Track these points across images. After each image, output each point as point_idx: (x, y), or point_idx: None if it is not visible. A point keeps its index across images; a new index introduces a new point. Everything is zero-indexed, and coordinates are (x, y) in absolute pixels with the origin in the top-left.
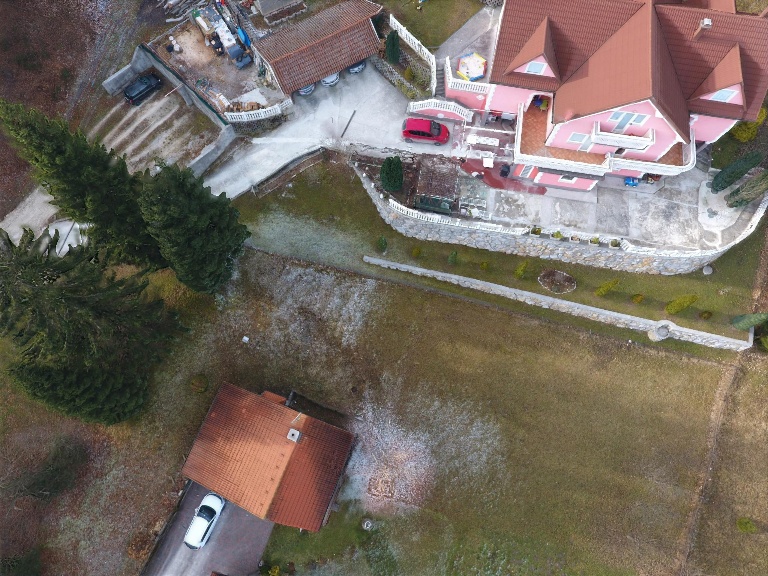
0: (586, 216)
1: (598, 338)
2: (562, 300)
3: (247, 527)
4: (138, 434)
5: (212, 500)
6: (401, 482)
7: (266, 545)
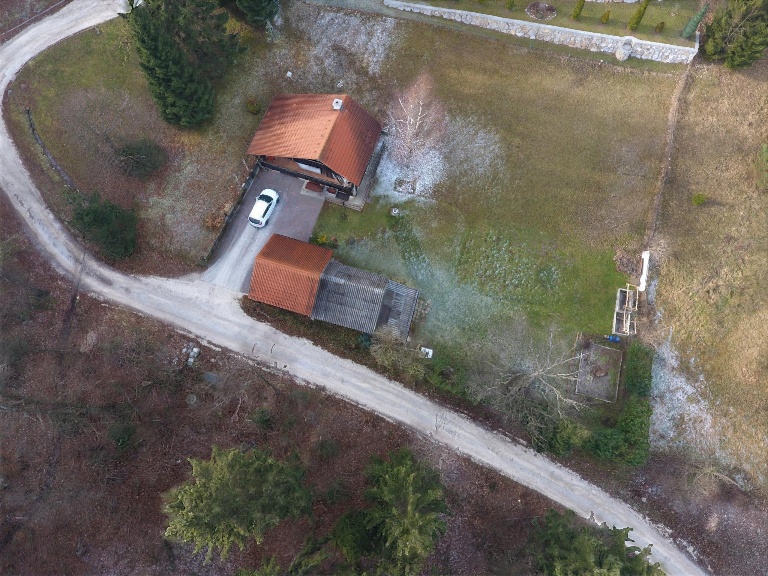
0: None
1: (576, 60)
2: (545, 25)
3: (298, 215)
4: (207, 141)
5: (269, 191)
6: (421, 182)
7: (314, 227)
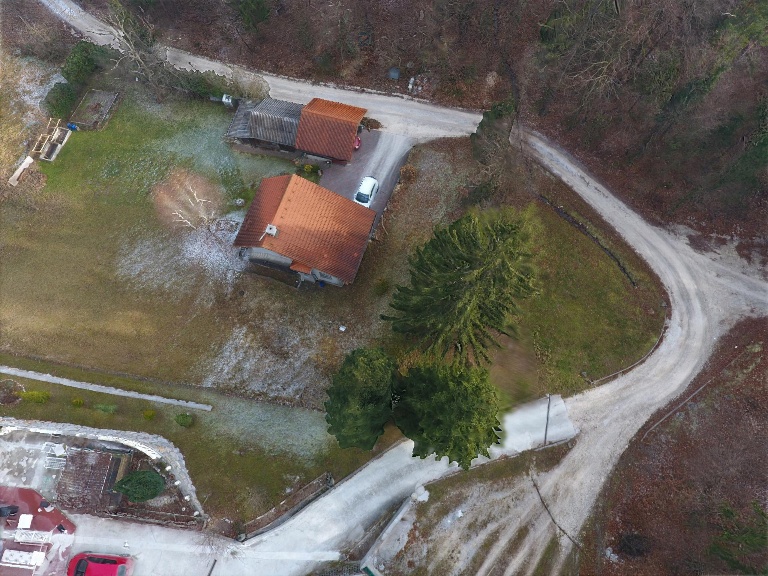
0: None
1: None
2: (8, 373)
3: None
4: None
5: None
6: None
7: None
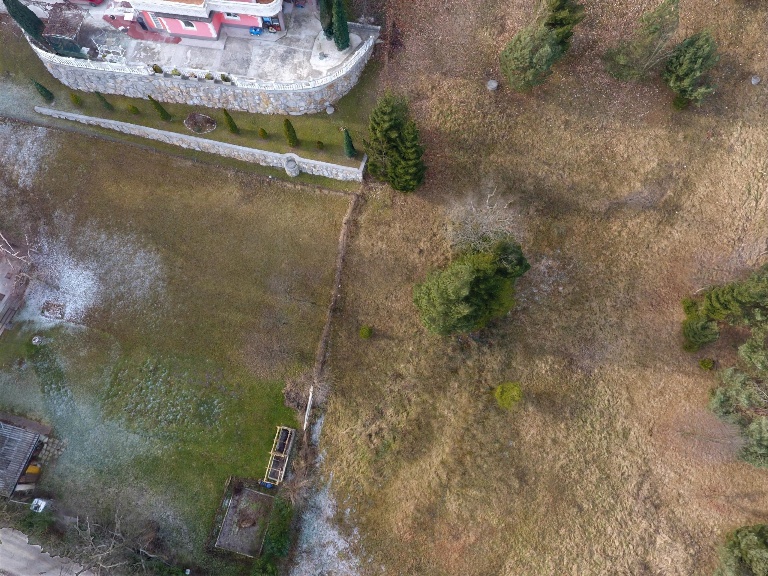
0: (212, 60)
1: (243, 175)
2: (203, 139)
3: None
4: None
5: None
6: (72, 305)
7: None
